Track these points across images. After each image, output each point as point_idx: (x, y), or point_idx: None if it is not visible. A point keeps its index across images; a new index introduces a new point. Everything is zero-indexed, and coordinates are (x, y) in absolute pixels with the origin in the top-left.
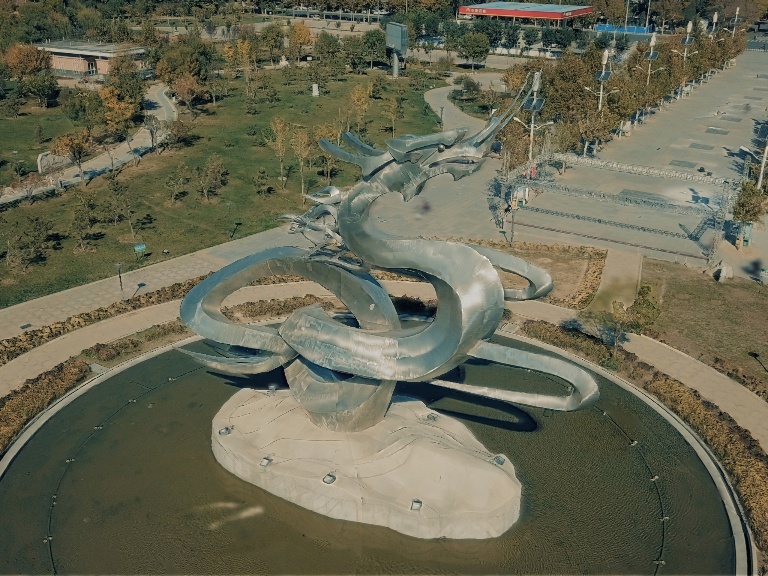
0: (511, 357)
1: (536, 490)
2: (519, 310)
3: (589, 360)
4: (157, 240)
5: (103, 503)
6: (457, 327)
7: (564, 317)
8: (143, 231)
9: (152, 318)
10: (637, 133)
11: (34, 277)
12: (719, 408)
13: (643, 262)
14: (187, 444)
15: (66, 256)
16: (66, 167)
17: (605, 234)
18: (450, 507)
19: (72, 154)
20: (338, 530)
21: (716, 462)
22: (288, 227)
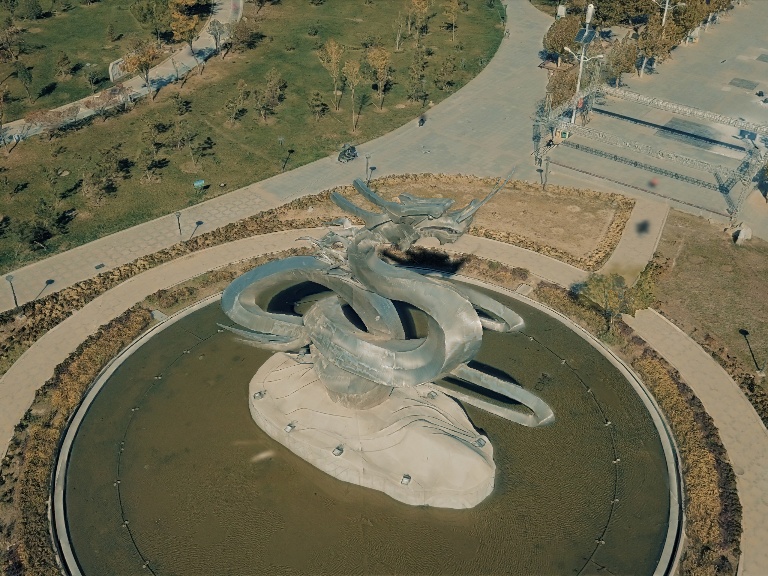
0: (485, 381)
1: (513, 464)
2: (536, 269)
3: (589, 330)
4: (215, 170)
5: (160, 452)
6: (441, 354)
7: (577, 279)
8: (203, 158)
9: (207, 262)
10: (706, 38)
11: (106, 210)
12: (693, 392)
13: (668, 215)
14: (229, 398)
15: (134, 187)
16: (135, 74)
17: (637, 181)
18: (433, 483)
19: (140, 70)
20: (345, 489)
21: (675, 448)
22: (337, 157)
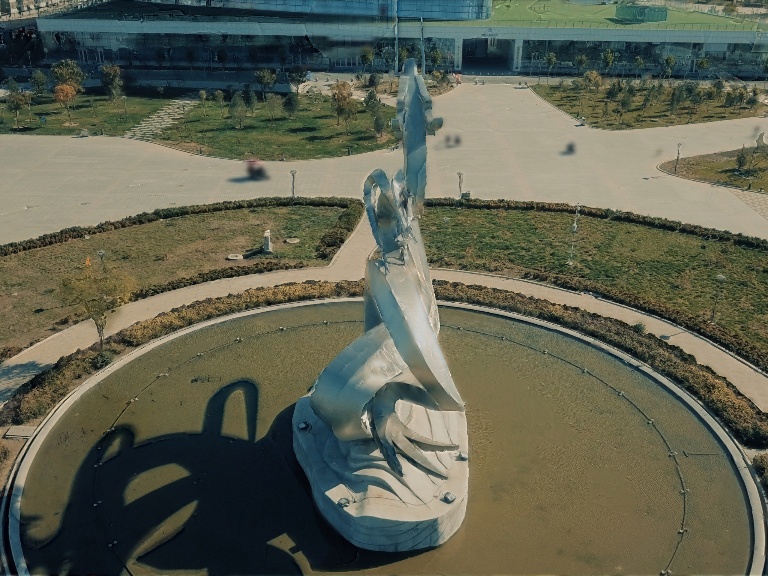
0: None
1: None
2: None
3: None
4: None
5: (592, 572)
6: None
7: None
8: None
9: None
10: None
11: None
12: None
13: None
14: (453, 571)
15: None
16: None
17: None
18: None
19: None
20: None
21: (245, 311)
22: None
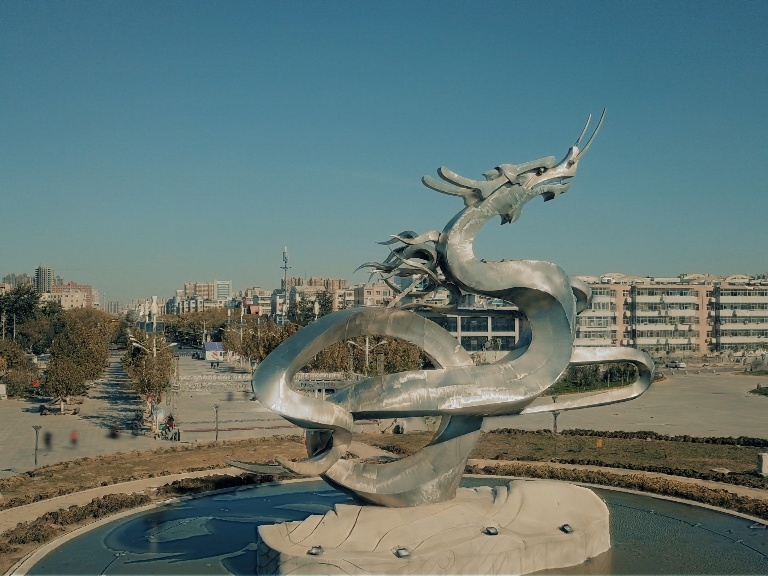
0: (601, 354)
1: None
2: None
3: None
4: None
5: None
6: (565, 333)
7: None
8: None
9: None
10: None
11: None
12: None
13: None
14: None
15: None
16: None
17: None
18: (583, 524)
19: None
20: None
21: None
22: None
